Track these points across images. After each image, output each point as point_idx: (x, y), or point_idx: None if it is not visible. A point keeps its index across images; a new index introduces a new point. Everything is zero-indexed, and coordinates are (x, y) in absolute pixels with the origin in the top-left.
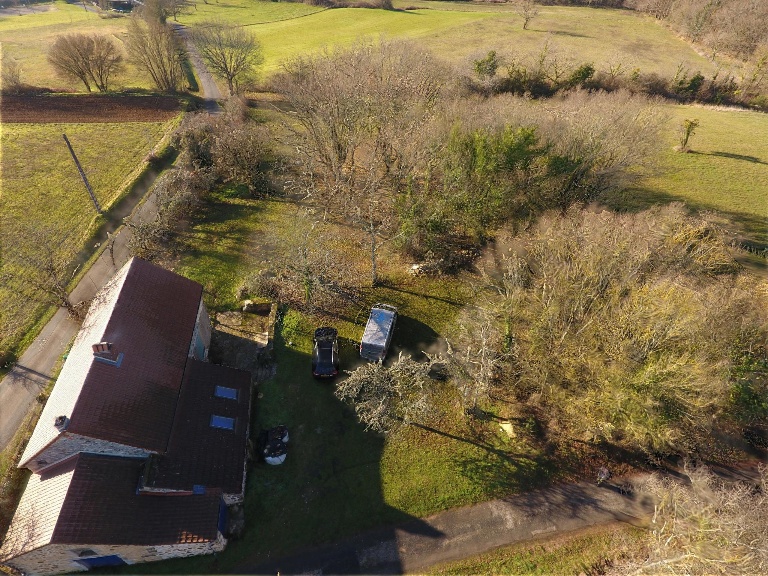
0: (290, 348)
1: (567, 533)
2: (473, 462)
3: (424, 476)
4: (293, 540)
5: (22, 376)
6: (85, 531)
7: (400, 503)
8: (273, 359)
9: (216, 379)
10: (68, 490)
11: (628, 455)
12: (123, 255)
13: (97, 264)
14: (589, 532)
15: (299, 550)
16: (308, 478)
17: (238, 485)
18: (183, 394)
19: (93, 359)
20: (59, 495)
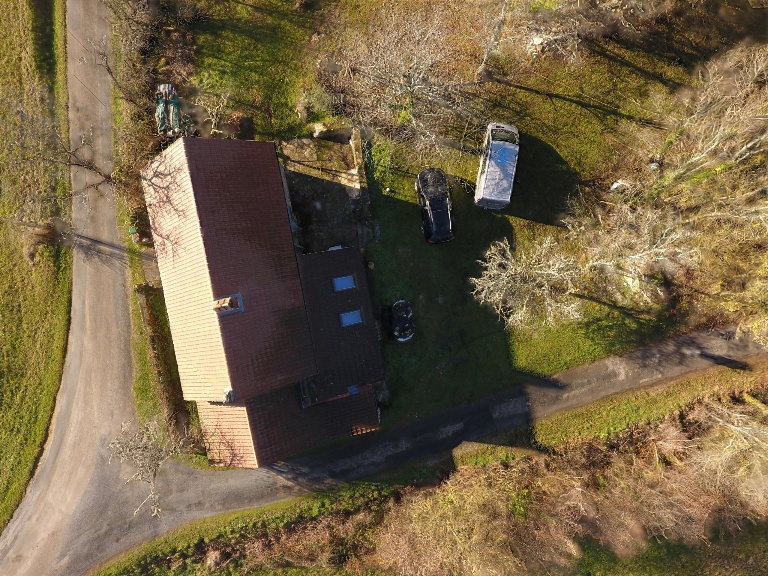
0: (389, 196)
1: (670, 379)
2: (595, 323)
3: (549, 342)
4: (435, 404)
5: (92, 250)
6: (279, 451)
7: (527, 368)
8: (373, 215)
9: (330, 271)
10: (250, 426)
11: (747, 304)
12: (98, 25)
13: (71, 49)
14: (689, 377)
15: (441, 411)
16: (439, 351)
17: (381, 373)
18: (306, 302)
19: (217, 315)
20: (242, 427)
